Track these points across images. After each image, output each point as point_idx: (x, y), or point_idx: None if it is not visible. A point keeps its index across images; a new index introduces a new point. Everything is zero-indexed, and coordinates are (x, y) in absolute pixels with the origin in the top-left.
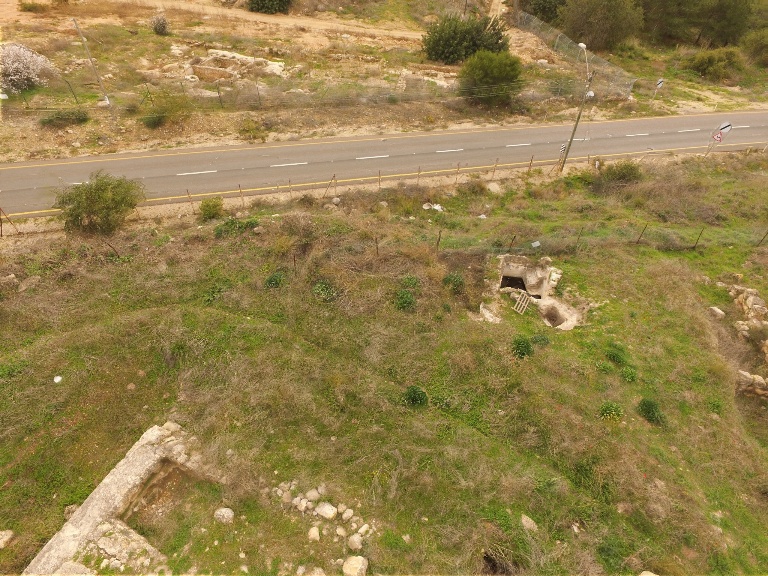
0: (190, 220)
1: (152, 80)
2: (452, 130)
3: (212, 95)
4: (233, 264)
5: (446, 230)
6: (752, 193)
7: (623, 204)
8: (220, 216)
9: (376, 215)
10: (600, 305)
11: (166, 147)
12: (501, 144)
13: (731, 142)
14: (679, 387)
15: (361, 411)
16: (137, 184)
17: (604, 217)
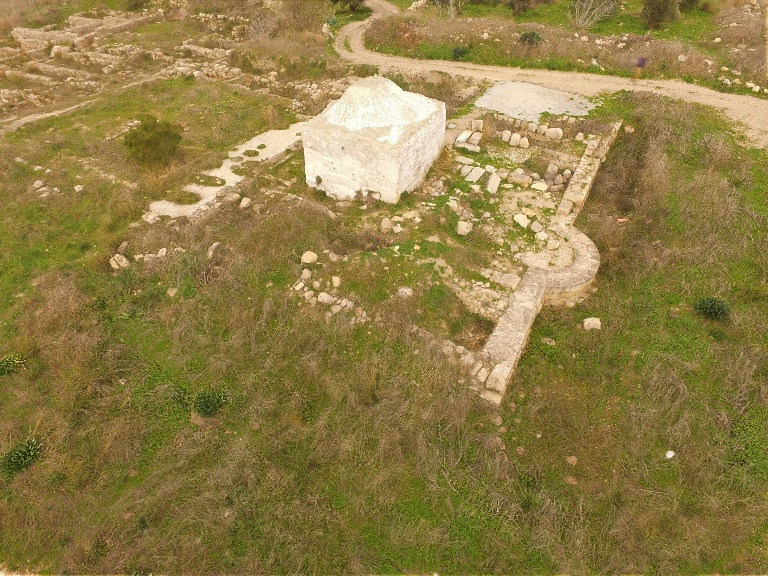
0: None
1: None
2: None
3: None
4: None
5: None
6: None
7: None
8: None
9: None
10: None
11: None
12: None
13: None
14: None
15: None
16: None
17: None
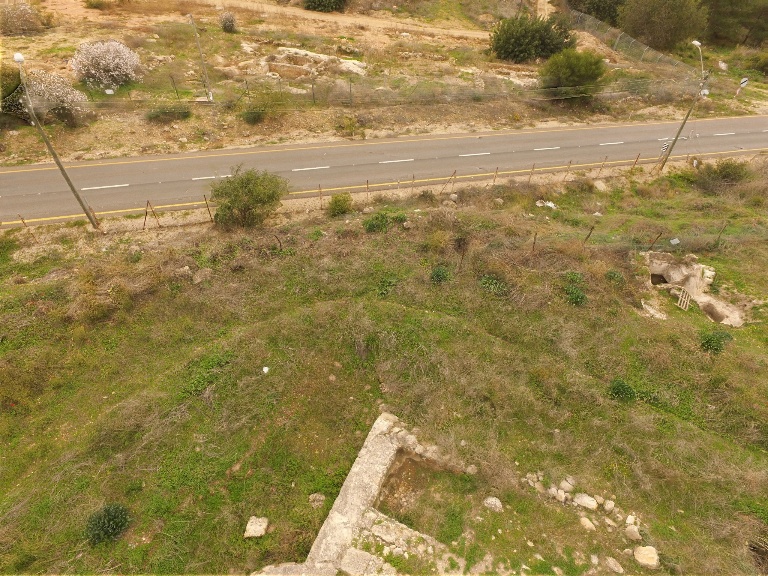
0: (318, 215)
1: (234, 77)
2: (542, 128)
3: (300, 92)
4: (391, 258)
5: (570, 227)
6: None
7: (741, 203)
8: (350, 211)
9: (509, 211)
10: (765, 302)
11: (270, 143)
12: (594, 142)
13: None
14: None
15: (574, 404)
16: (284, 178)
17: (728, 215)
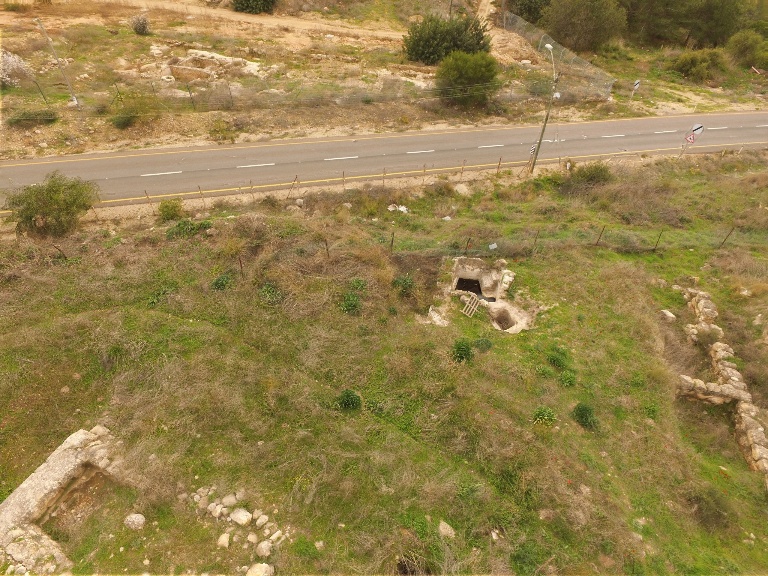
0: (150, 221)
1: (128, 80)
2: (425, 131)
3: (186, 95)
4: (182, 266)
5: (408, 232)
6: (720, 195)
7: (588, 206)
8: (179, 217)
9: (334, 217)
10: (549, 308)
11: (134, 148)
12: (473, 145)
13: (707, 143)
14: (617, 392)
15: (292, 415)
16: (90, 185)
17: (567, 219)
